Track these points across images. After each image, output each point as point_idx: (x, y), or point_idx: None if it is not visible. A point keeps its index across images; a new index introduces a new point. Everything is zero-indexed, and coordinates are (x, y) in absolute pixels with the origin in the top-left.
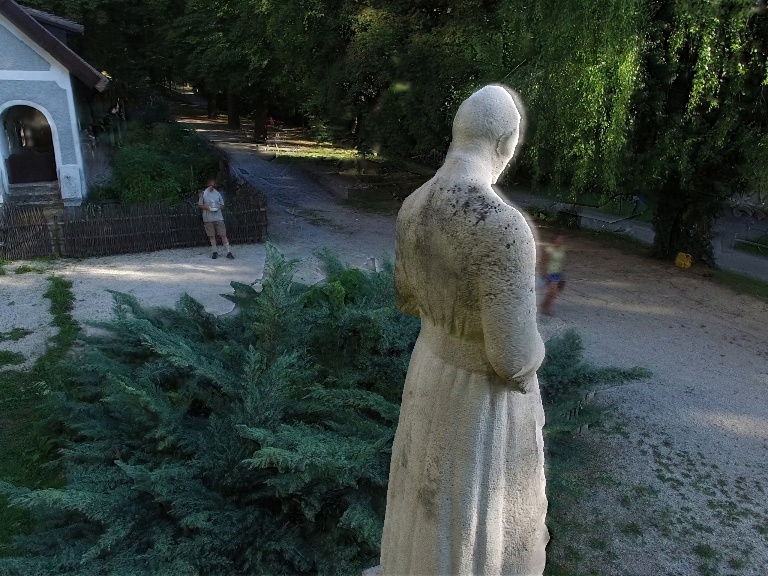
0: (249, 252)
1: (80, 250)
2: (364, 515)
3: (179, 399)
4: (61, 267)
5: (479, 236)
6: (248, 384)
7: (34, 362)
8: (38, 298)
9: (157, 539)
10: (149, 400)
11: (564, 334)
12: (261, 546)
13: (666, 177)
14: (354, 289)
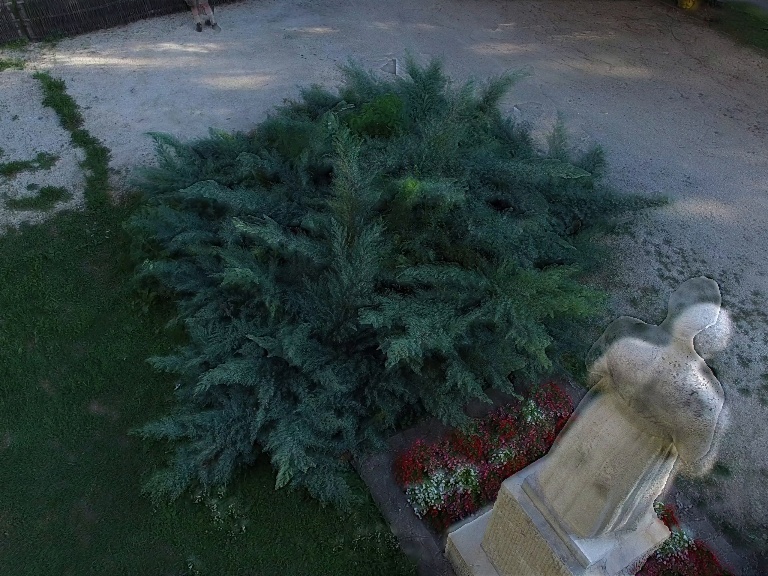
0: (233, 17)
1: (50, 31)
2: (461, 370)
3: (261, 253)
4: (39, 57)
5: (693, 401)
6: (340, 258)
7: (83, 198)
8: (39, 108)
9: (299, 394)
10: (254, 276)
11: (588, 147)
12: (375, 386)
13: None
14: (392, 116)
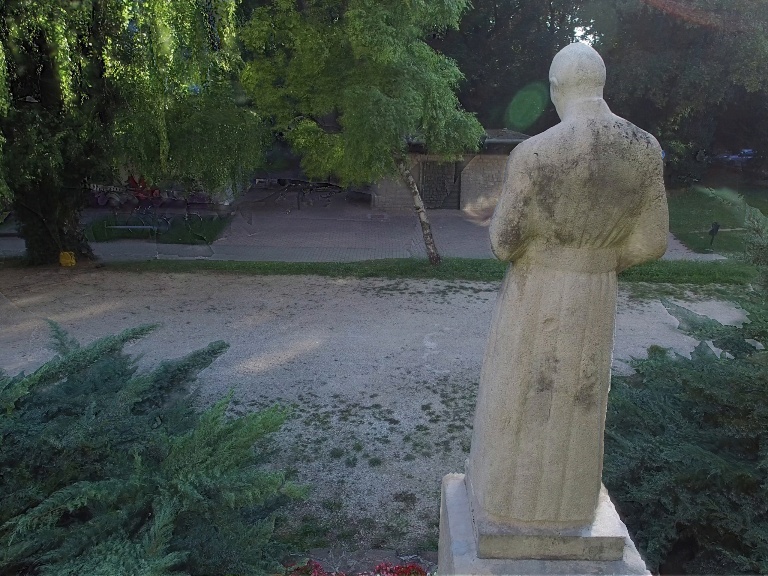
0: None
1: None
2: None
3: None
4: None
5: None
6: None
7: None
8: None
9: None
10: None
11: None
12: None
13: (40, 176)
14: None
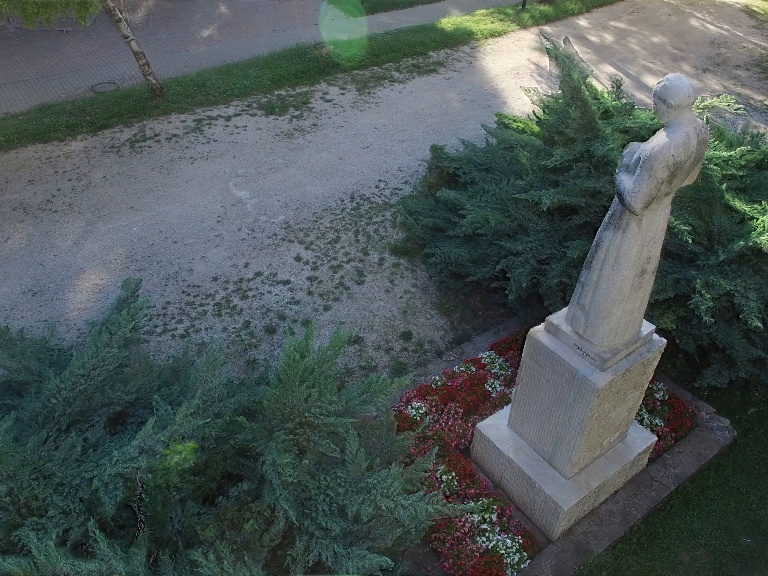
0: None
1: None
2: None
3: None
4: None
5: None
6: None
7: None
8: None
9: None
10: None
11: None
12: None
13: None
14: None
